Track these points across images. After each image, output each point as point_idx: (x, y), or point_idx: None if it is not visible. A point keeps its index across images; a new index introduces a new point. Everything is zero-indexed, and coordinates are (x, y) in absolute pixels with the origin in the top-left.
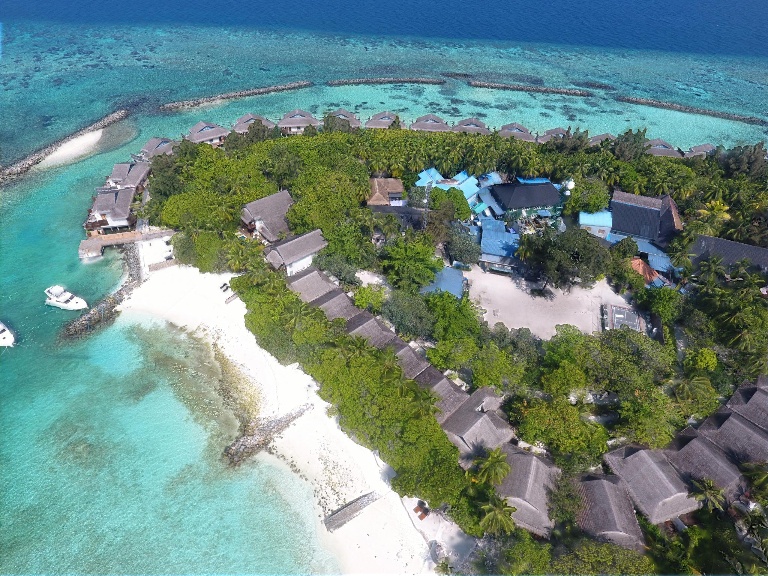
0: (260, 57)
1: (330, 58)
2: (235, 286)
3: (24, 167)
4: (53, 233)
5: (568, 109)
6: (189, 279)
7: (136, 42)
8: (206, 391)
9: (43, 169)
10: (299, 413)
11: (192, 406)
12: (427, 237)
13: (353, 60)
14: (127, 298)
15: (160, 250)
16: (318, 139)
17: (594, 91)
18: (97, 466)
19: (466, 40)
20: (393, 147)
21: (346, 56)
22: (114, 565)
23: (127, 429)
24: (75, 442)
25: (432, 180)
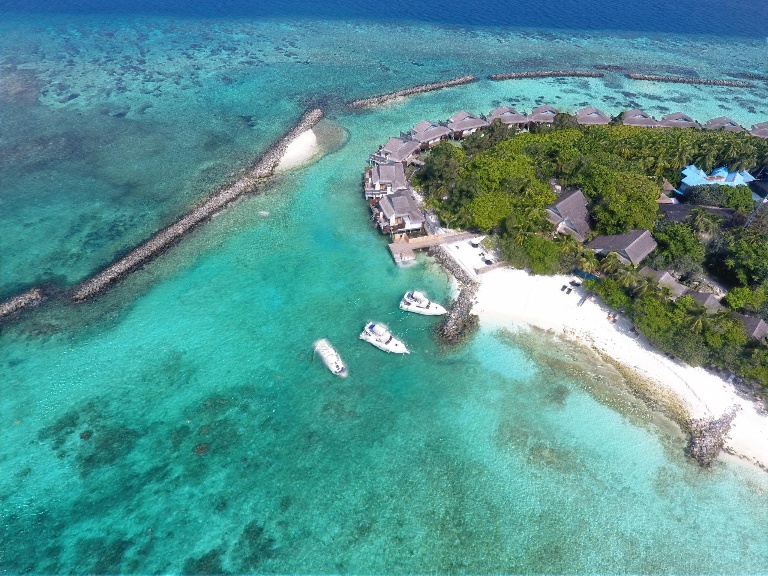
0: (404, 51)
1: (472, 51)
2: (602, 289)
3: (269, 170)
4: (346, 237)
5: (742, 101)
6: (522, 282)
7: (270, 37)
8: (621, 394)
9: (286, 171)
10: (734, 414)
11: (619, 409)
12: (765, 236)
13: (496, 53)
14: (475, 302)
15: (471, 253)
16: (556, 137)
17: (752, 82)
18: (575, 470)
19: (589, 30)
20: (647, 144)
21: (486, 49)
22: (668, 567)
23: (574, 433)
24: (536, 447)
25: (703, 177)
